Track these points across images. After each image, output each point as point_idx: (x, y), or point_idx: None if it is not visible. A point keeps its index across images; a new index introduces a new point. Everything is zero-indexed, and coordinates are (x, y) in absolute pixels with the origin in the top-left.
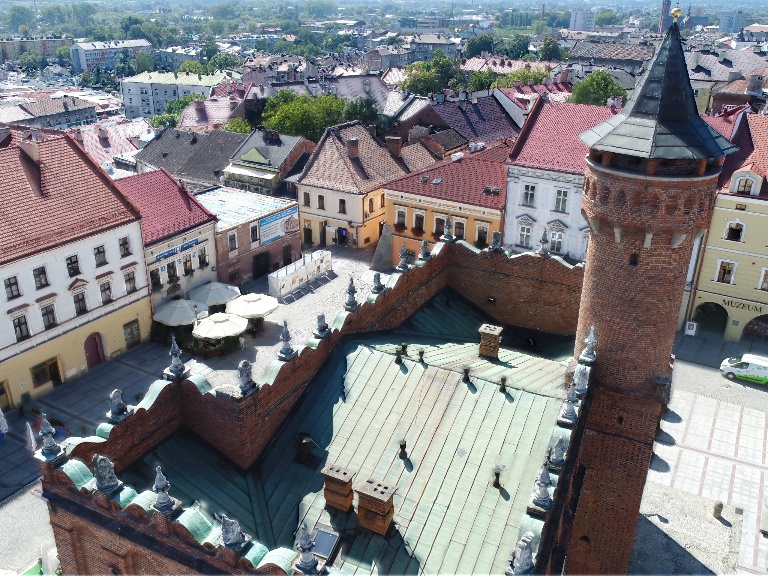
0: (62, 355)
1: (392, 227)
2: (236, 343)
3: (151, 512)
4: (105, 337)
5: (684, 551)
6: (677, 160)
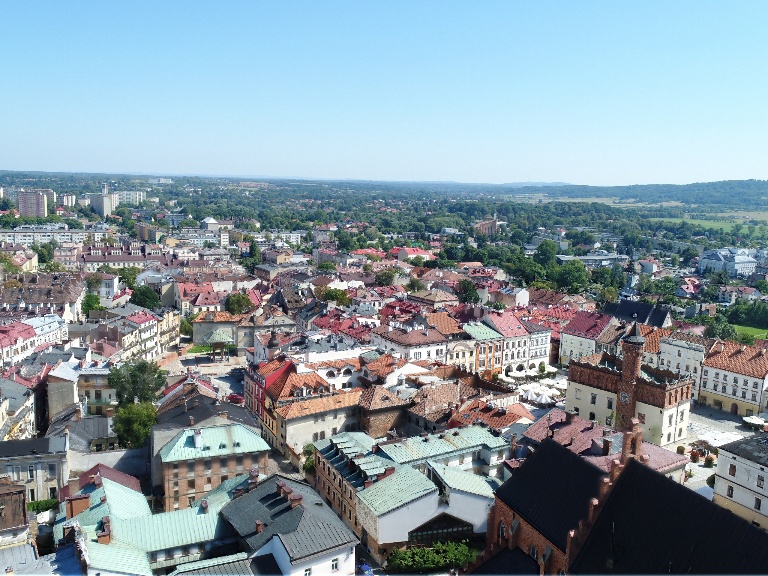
0: None
1: None
2: None
3: None
4: (739, 408)
5: None
6: None
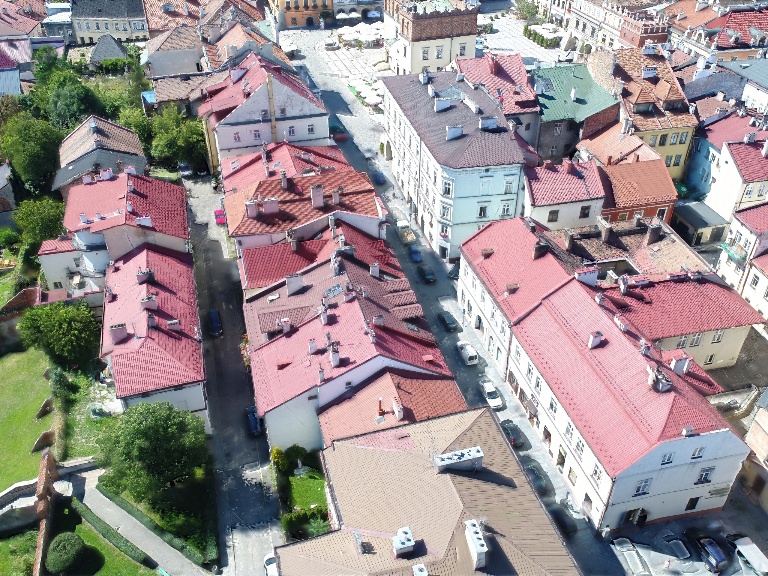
0: None
1: (284, 9)
2: (294, 53)
3: (434, 12)
4: None
5: None
6: None
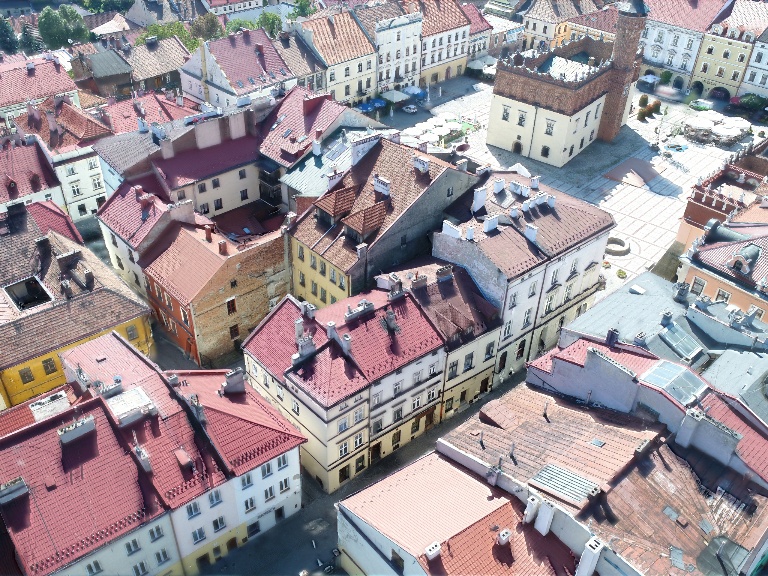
0: (440, 72)
1: None
2: None
3: None
4: (452, 69)
5: (640, 136)
6: (636, 13)
